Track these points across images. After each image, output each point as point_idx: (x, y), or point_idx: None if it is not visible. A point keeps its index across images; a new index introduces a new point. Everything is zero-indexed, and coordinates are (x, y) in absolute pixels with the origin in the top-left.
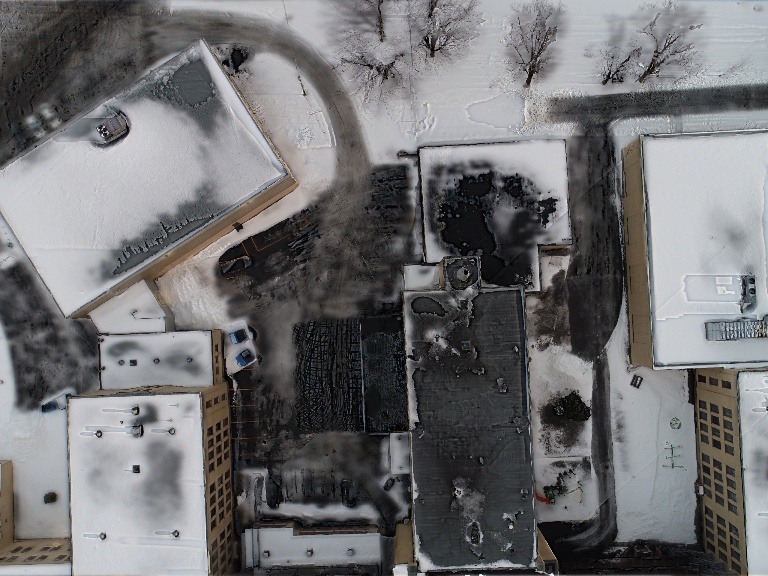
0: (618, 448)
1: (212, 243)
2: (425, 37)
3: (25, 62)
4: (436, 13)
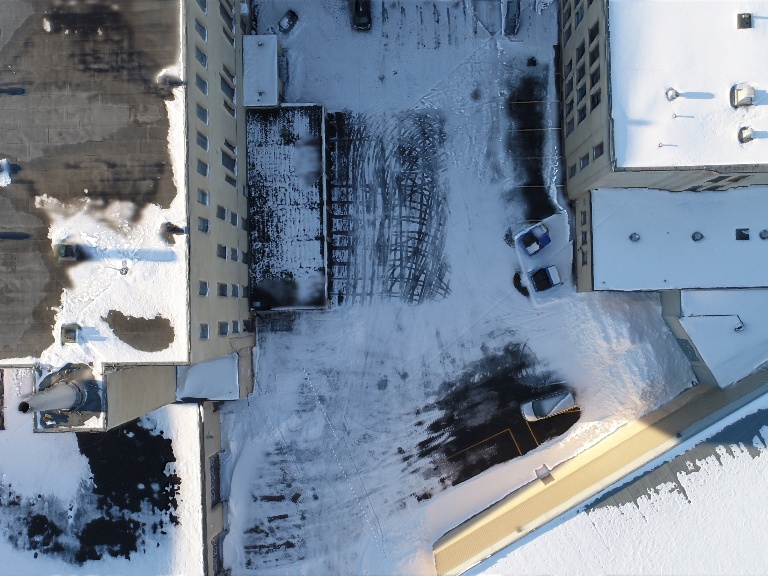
0: None
1: (593, 446)
2: None
3: None
4: None
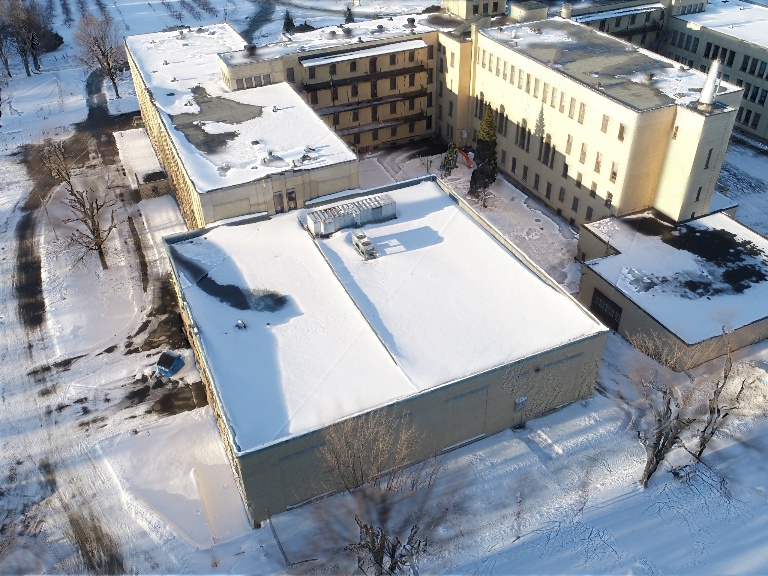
0: None
1: None
2: None
3: None
4: None
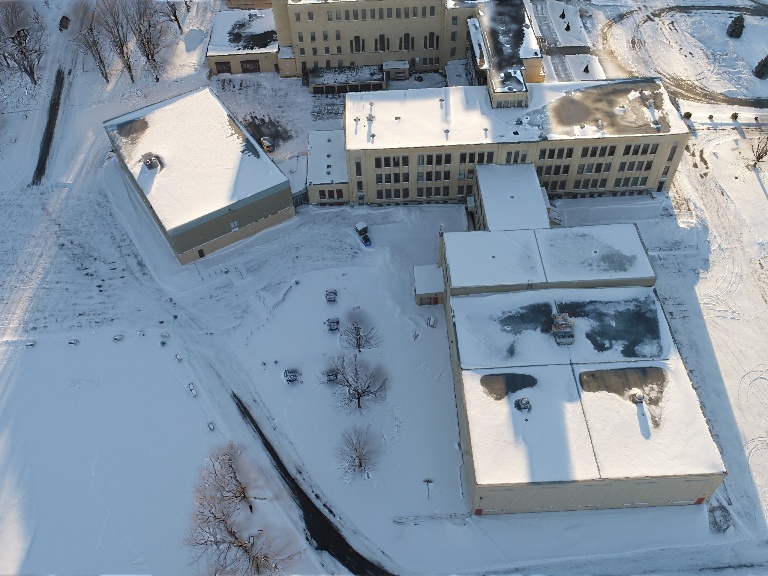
0: None
1: None
2: (141, 43)
3: (72, 268)
4: (127, 43)
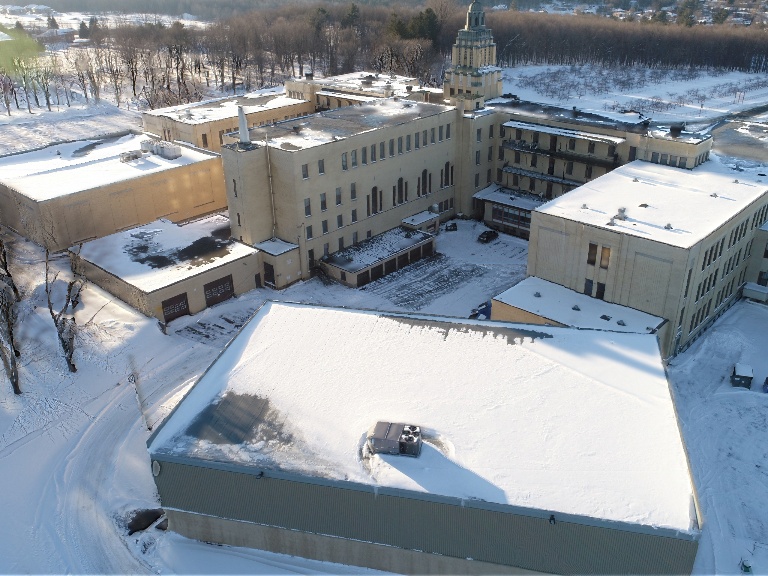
0: None
1: None
2: (3, 308)
3: None
4: None
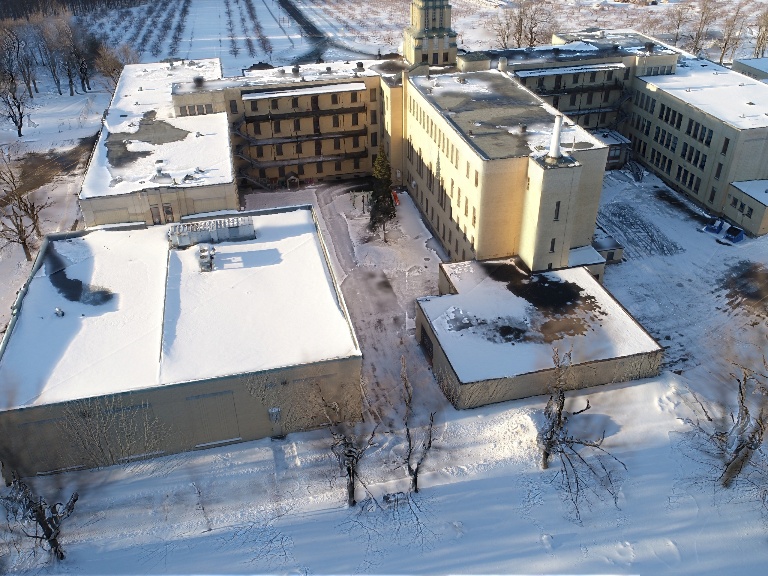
0: (322, 227)
1: None
2: None
3: None
4: None
